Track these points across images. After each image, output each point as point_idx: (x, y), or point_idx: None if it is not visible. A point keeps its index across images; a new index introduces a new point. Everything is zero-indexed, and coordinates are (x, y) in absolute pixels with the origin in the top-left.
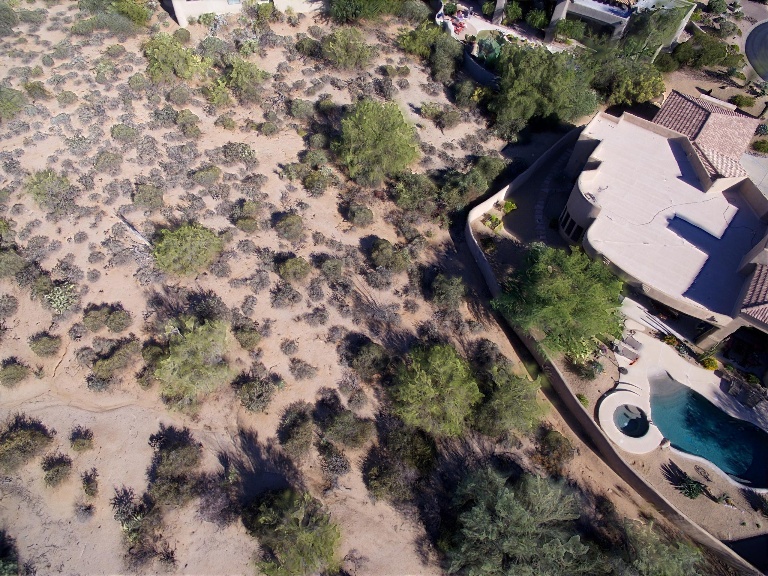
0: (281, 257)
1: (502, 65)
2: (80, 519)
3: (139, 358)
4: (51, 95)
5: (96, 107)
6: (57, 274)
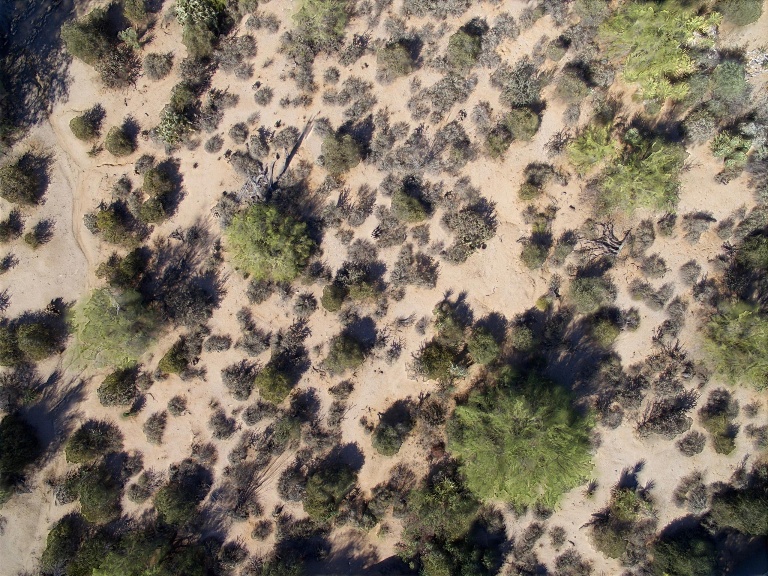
0: (290, 360)
1: None
2: None
3: (129, 249)
4: None
5: None
6: None
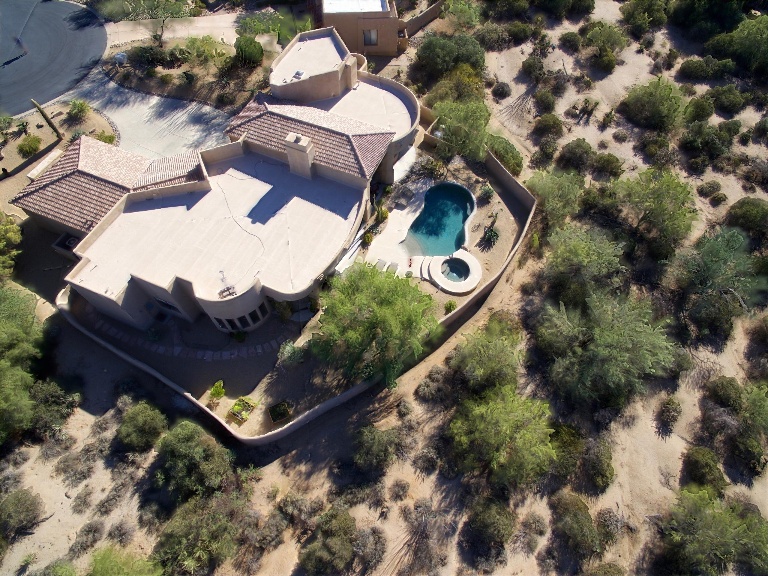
0: None
1: None
2: None
3: None
4: None
5: None
6: None
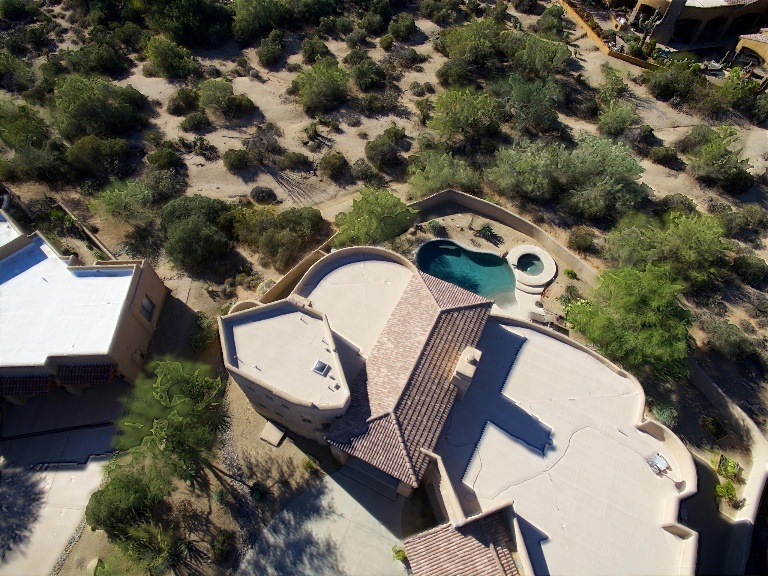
0: None
1: None
2: None
3: None
4: None
5: None
6: None
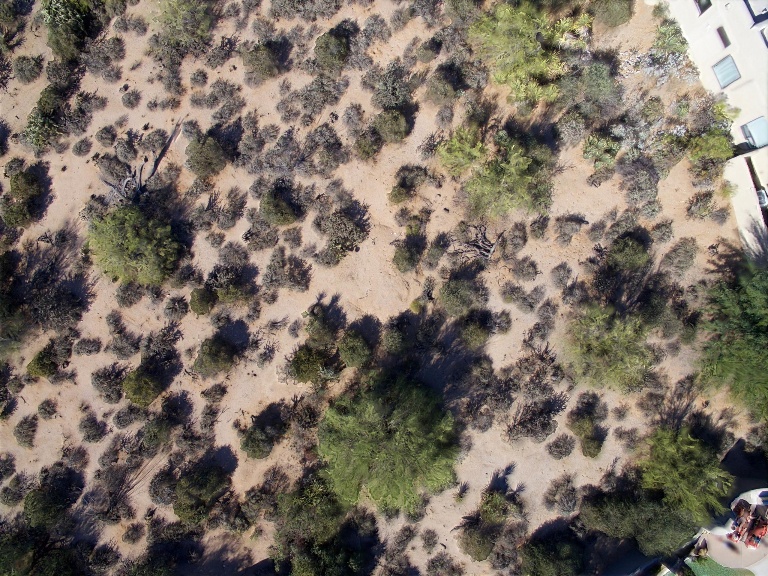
0: (159, 363)
1: None
2: None
3: None
4: None
5: None
6: None
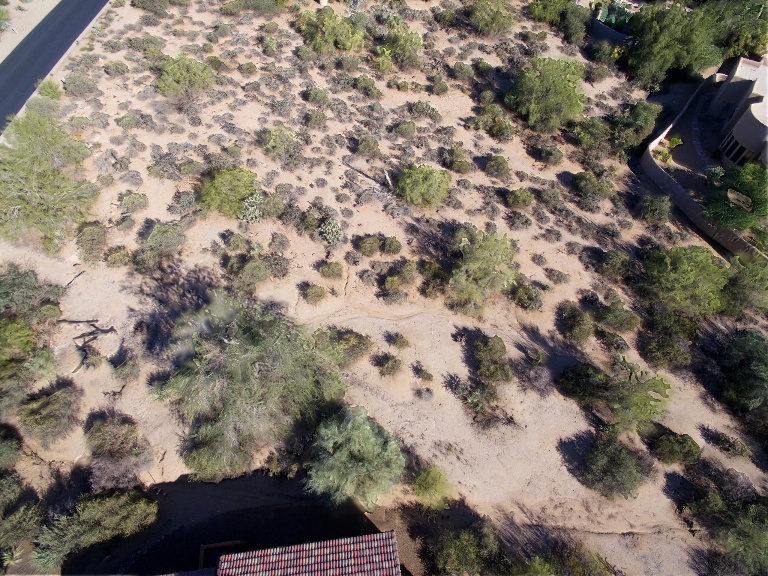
0: (503, 190)
1: (644, 24)
2: (426, 398)
3: (417, 275)
4: (230, 68)
5: (276, 76)
6: (314, 213)
